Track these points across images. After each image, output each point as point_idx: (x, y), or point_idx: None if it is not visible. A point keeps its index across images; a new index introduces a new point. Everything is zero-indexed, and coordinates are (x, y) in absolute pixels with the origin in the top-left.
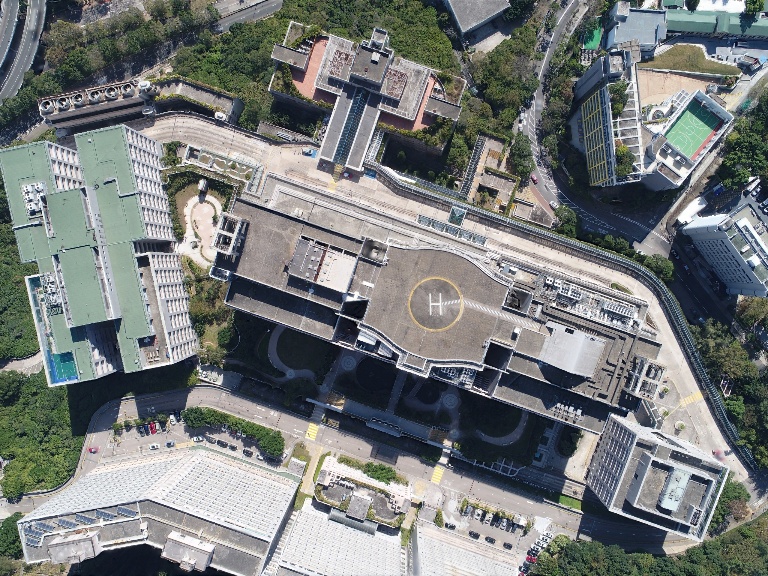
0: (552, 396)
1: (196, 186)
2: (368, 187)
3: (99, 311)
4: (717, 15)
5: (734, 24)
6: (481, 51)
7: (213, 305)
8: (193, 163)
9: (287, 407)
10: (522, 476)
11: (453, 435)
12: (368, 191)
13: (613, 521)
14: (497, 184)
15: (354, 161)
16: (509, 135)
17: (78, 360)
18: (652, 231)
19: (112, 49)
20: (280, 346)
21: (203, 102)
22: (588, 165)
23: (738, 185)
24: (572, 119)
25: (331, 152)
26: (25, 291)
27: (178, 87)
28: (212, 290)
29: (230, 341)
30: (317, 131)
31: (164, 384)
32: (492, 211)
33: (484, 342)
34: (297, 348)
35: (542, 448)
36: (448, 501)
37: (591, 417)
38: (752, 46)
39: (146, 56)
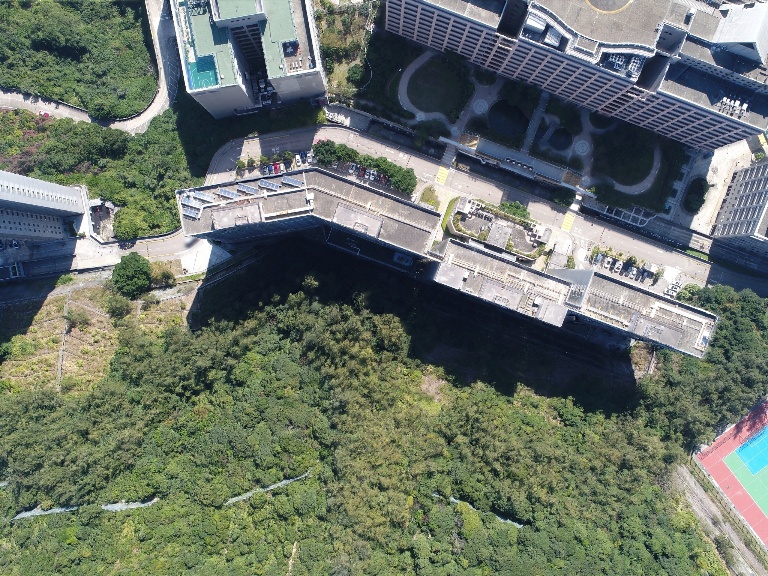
0: (718, 91)
1: None
2: None
3: (248, 4)
4: None
5: None
6: None
7: (345, 40)
8: None
9: (417, 149)
10: (650, 229)
11: (585, 182)
12: None
13: (740, 273)
14: None
15: None
16: None
17: (219, 64)
18: None
19: None
20: (411, 87)
21: None
22: None
23: None
24: None
25: None
26: (125, 57)
27: None
28: (347, 18)
29: (361, 78)
30: None
31: (292, 120)
32: None
33: (657, 25)
34: (428, 90)
35: (671, 200)
36: (578, 249)
37: (756, 113)
38: None
39: None
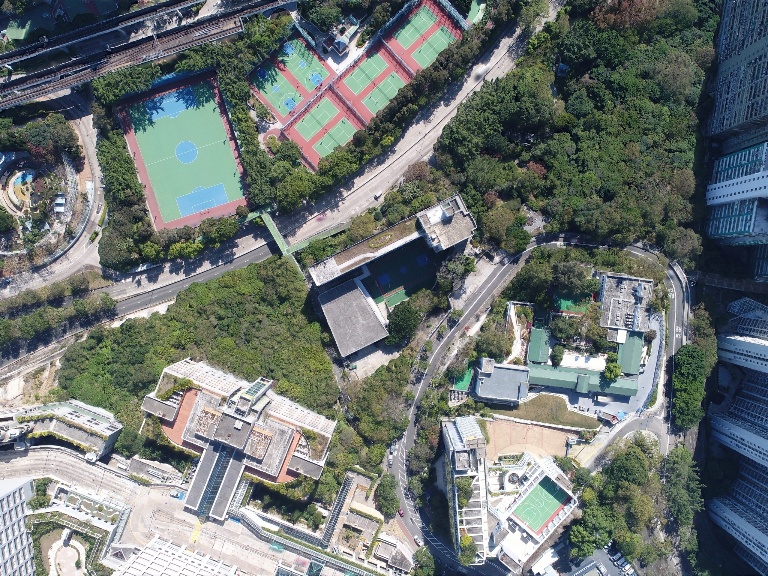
0: None
1: (61, 531)
2: (232, 531)
3: None
4: (579, 372)
5: (594, 384)
6: (356, 383)
7: None
8: (59, 509)
9: None
10: None
11: None
12: (232, 534)
13: None
14: (361, 523)
15: (218, 511)
16: (377, 472)
17: None
18: (509, 574)
19: (4, 337)
20: None
21: (75, 442)
22: (449, 511)
23: (583, 556)
24: (437, 462)
25: (196, 501)
26: None
27: (52, 423)
28: None
29: None
30: (187, 471)
31: None
32: (350, 562)
33: None
34: None
35: None
36: None
37: None
38: (612, 399)
39: (42, 334)
